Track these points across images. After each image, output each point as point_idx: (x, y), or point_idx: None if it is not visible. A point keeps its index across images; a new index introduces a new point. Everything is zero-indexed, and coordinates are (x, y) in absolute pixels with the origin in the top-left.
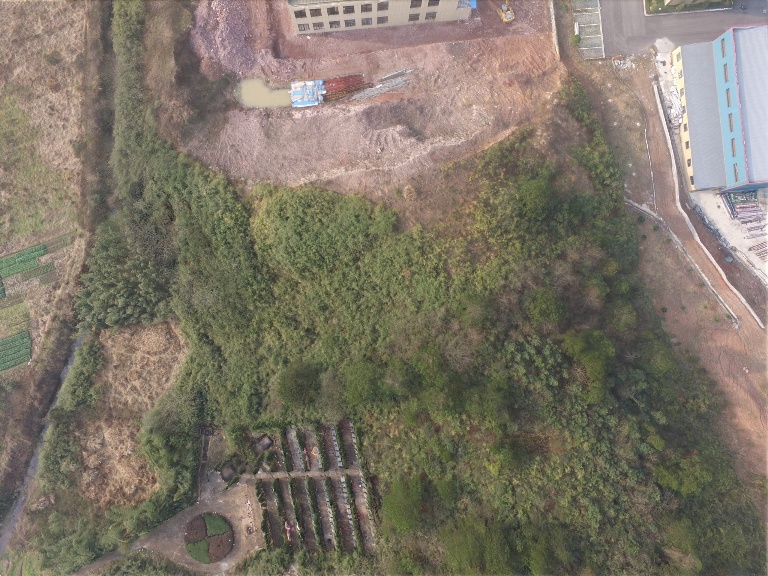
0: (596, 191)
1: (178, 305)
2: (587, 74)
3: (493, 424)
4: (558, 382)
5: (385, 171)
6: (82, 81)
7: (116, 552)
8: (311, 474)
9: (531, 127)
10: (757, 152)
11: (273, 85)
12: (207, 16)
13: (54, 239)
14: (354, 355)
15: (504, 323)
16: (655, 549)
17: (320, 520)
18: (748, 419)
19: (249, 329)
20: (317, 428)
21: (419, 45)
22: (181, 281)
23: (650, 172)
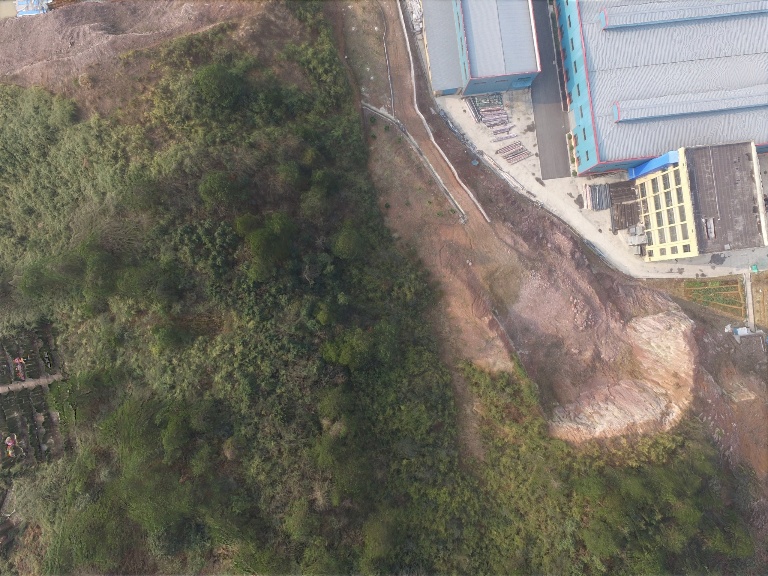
0: None
1: None
2: None
3: (158, 307)
4: (229, 263)
5: (64, 61)
6: None
7: None
8: (26, 385)
9: (237, 22)
10: (480, 48)
11: None
12: None
13: None
14: None
15: (177, 207)
16: (314, 422)
17: (36, 431)
18: (460, 307)
19: None
20: (19, 333)
21: None
22: None
23: (387, 75)
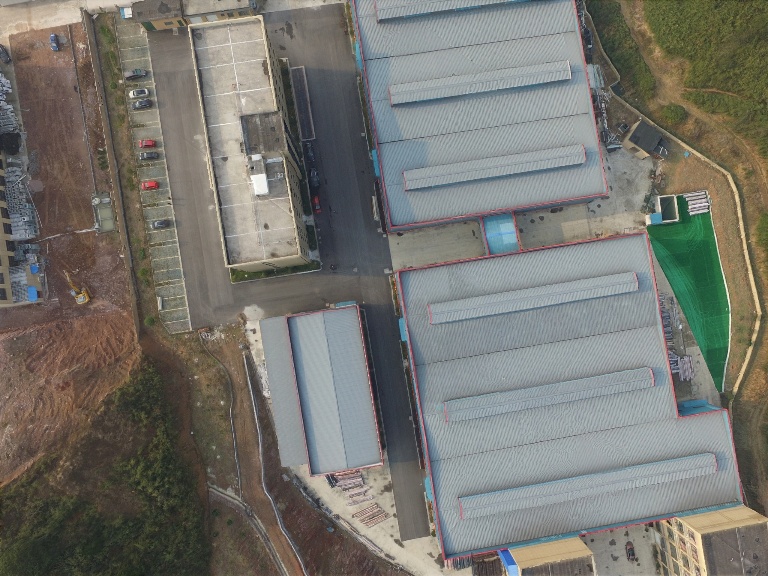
0: (142, 506)
1: None
2: (173, 349)
3: None
4: None
5: None
6: None
7: None
8: None
9: (59, 452)
10: (321, 441)
11: None
12: None
13: None
14: None
15: None
16: None
17: None
18: None
19: None
20: None
21: None
22: None
23: (234, 454)
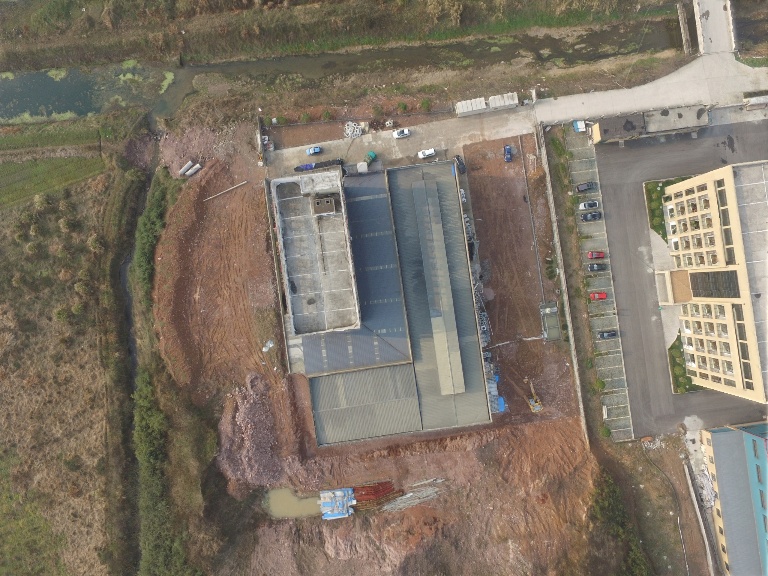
0: None
1: None
2: (617, 457)
3: None
4: None
5: None
6: (105, 486)
7: None
8: None
9: (569, 571)
10: None
11: (302, 495)
12: (232, 435)
13: None
14: None
15: None
16: None
17: None
18: None
19: None
20: None
21: (448, 447)
22: None
23: (685, 564)
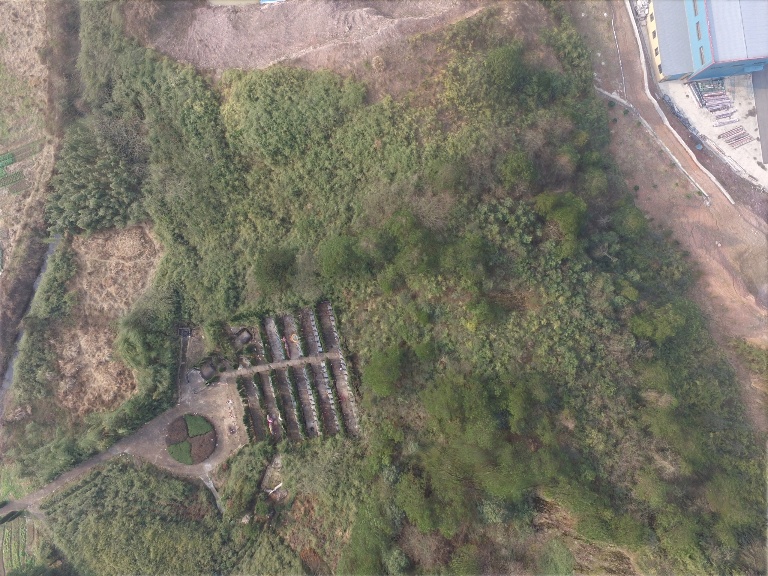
0: (565, 71)
1: (151, 205)
2: None
3: (469, 283)
4: (532, 241)
5: (353, 44)
6: None
7: (96, 458)
8: (291, 363)
9: (498, 7)
10: (721, 33)
11: None
12: None
13: (22, 147)
14: (329, 236)
15: (476, 186)
16: (632, 395)
17: (302, 408)
18: (721, 287)
19: (224, 223)
20: (295, 311)
21: None
22: (153, 181)
23: (619, 61)
